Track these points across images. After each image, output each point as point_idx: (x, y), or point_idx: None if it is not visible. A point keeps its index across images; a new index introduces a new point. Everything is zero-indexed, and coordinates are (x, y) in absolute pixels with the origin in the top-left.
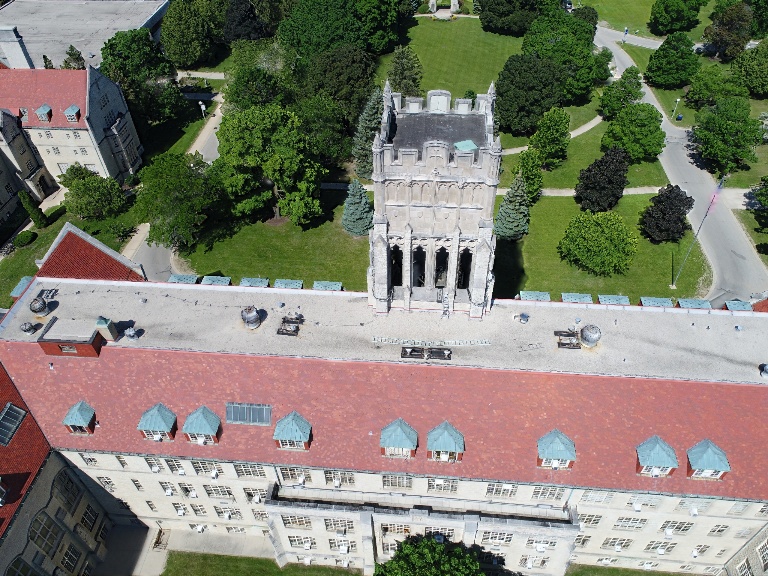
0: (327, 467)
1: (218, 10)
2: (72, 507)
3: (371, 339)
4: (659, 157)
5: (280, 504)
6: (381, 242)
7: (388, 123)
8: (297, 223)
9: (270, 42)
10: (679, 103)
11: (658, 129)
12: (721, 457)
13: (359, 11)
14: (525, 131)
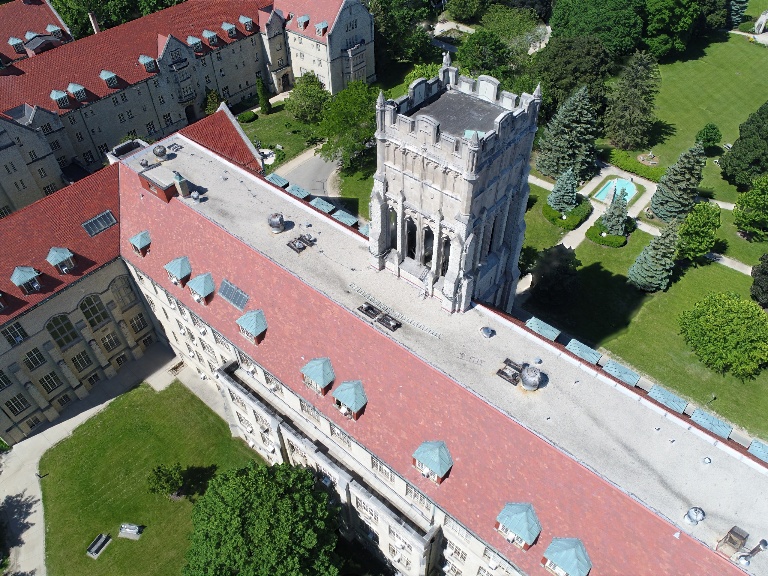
0: (264, 367)
1: None
2: (125, 307)
3: (349, 283)
4: None
5: (226, 377)
6: (377, 198)
7: (419, 91)
8: None
9: (521, 13)
10: None
11: None
12: (581, 565)
13: (648, 8)
14: None
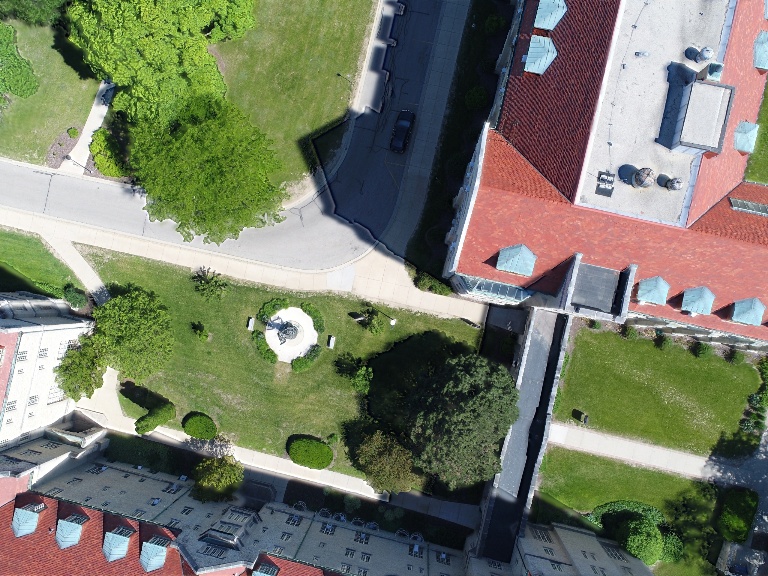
0: None
1: None
2: None
3: None
4: None
5: None
6: None
7: None
8: None
9: None
10: None
11: None
12: None
13: None
14: None
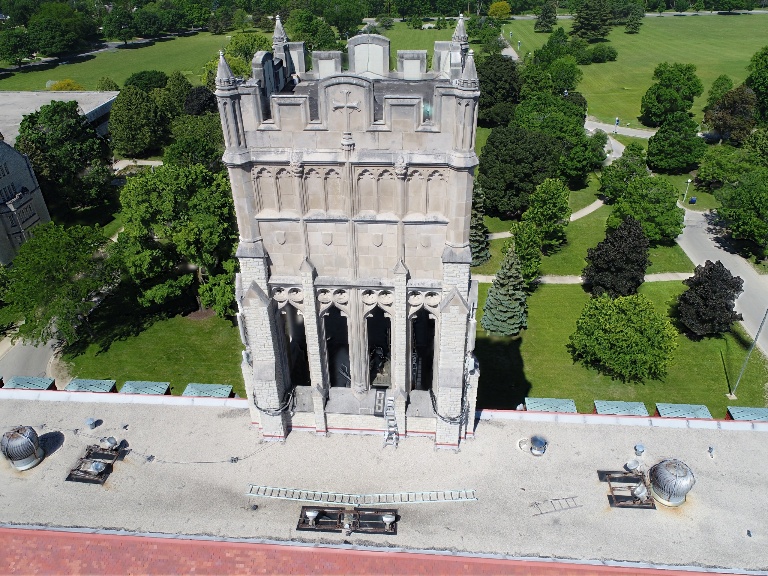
0: None
1: (177, 101)
2: None
3: (245, 490)
4: (677, 241)
5: None
6: (255, 295)
7: (268, 73)
8: (222, 315)
9: (216, 114)
10: (688, 187)
11: (675, 206)
12: None
13: None
14: (515, 214)
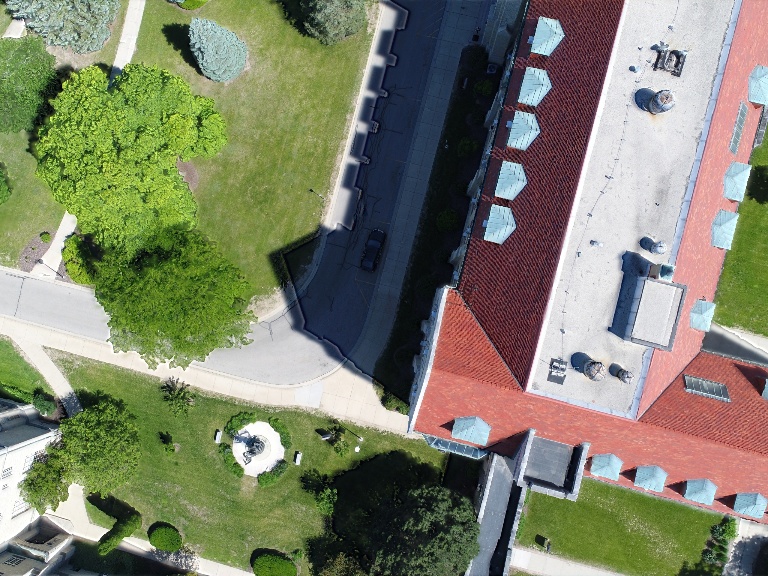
0: None
1: None
2: None
3: None
4: None
5: (764, 129)
6: None
7: None
8: (226, 138)
9: None
10: None
11: None
12: None
13: None
14: None
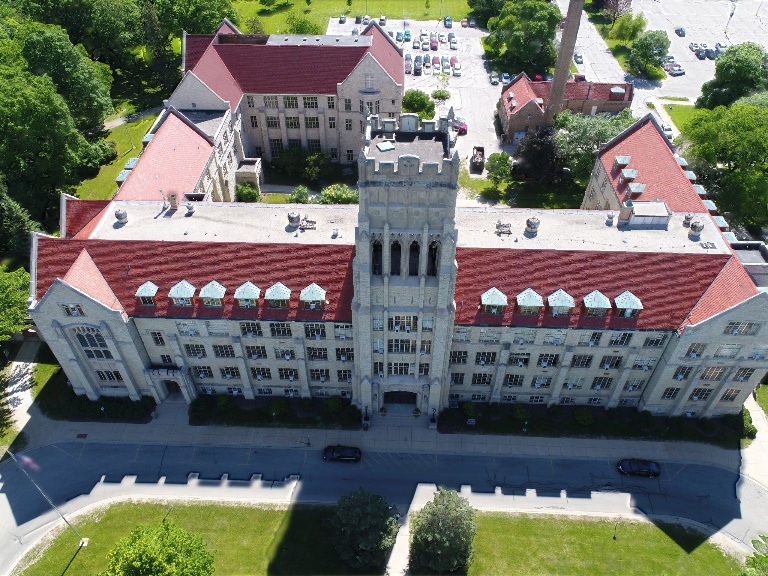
0: None
1: None
2: None
3: None
4: None
5: None
6: None
7: None
8: None
9: None
10: None
11: None
12: None
13: None
14: None
